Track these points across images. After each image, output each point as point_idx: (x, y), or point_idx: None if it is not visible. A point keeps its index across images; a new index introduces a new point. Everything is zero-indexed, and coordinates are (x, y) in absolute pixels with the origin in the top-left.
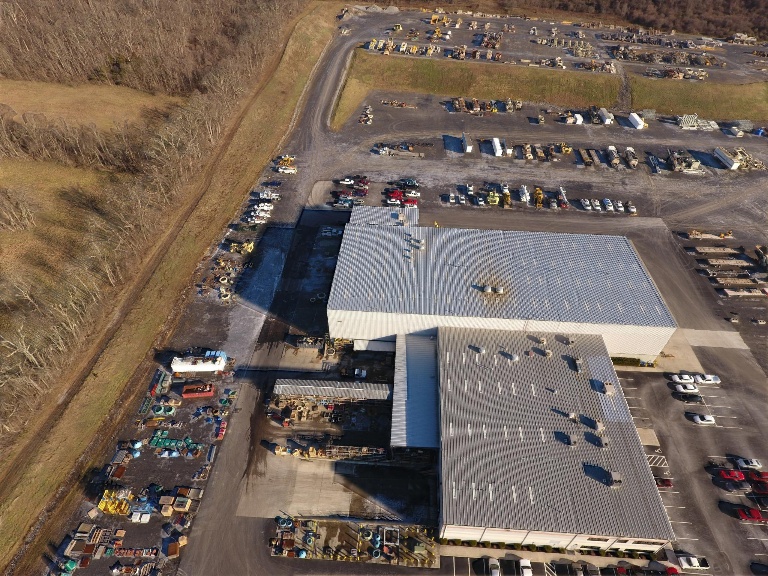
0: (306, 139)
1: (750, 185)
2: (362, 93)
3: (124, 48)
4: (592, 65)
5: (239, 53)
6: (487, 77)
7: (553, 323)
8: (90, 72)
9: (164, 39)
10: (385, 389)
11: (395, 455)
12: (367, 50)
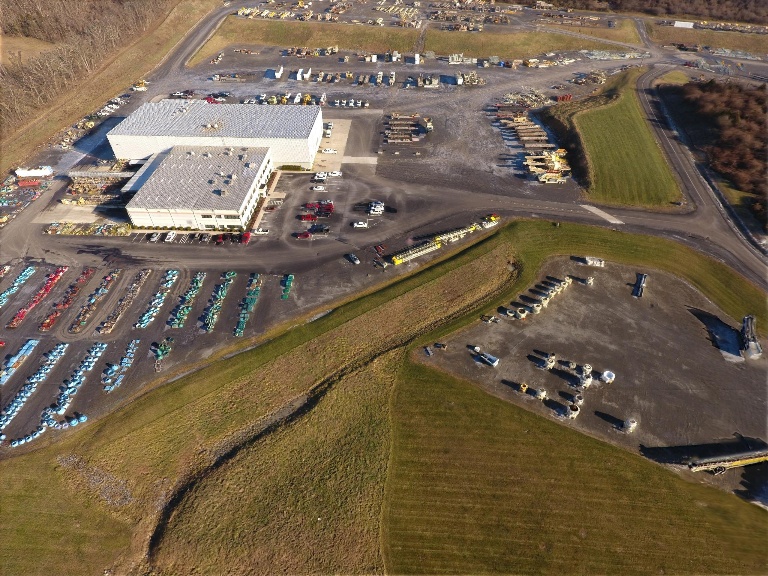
0: (164, 73)
1: (464, 93)
2: (222, 45)
3: (33, 10)
4: (403, 23)
5: (124, 15)
6: (321, 33)
7: (238, 139)
8: (6, 27)
9: (67, 5)
10: (132, 173)
11: (126, 198)
12: (236, 16)
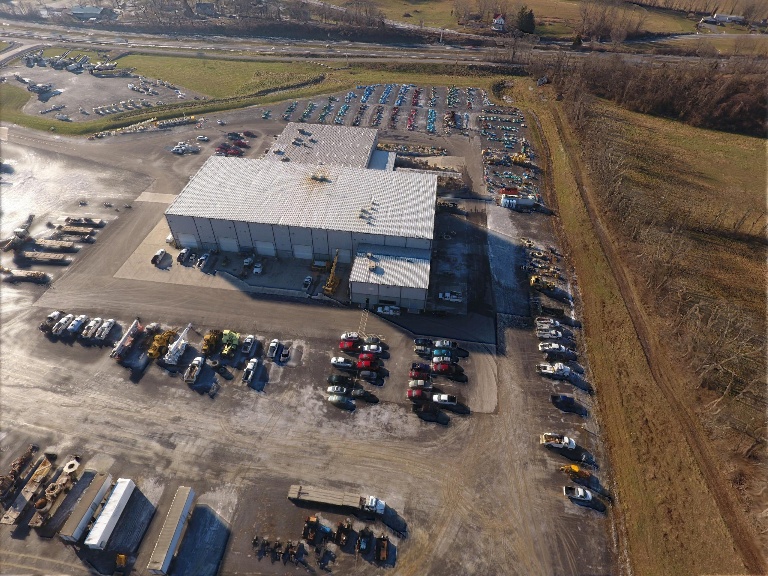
0: None
1: None
2: None
3: None
4: None
5: None
6: None
7: None
8: None
9: None
10: (398, 170)
11: None
12: None
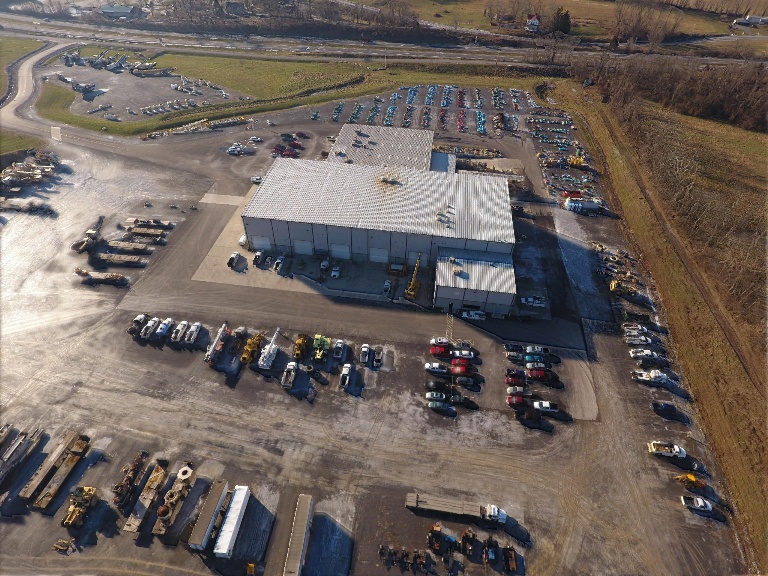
0: None
1: None
2: None
3: None
4: None
5: None
6: None
7: None
8: None
9: None
10: (460, 172)
11: None
12: None
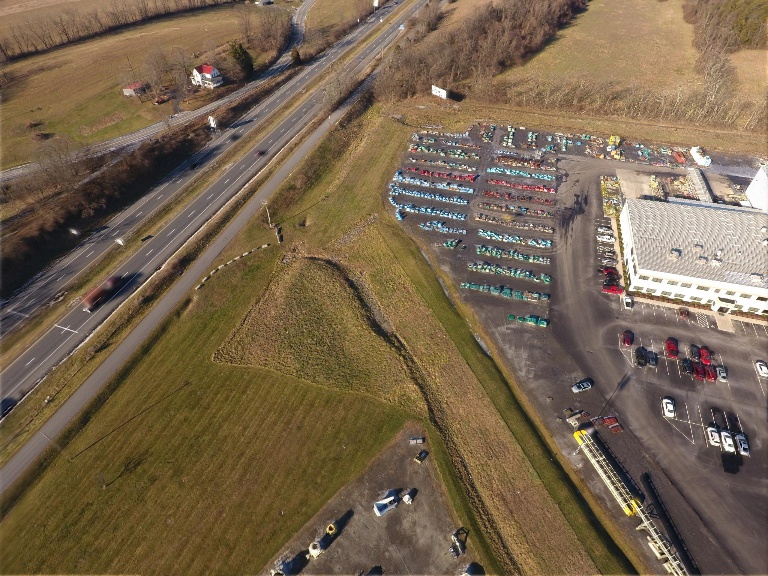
0: None
1: None
2: None
3: None
4: None
5: None
6: None
7: None
8: None
9: None
10: (708, 200)
11: None
12: None
